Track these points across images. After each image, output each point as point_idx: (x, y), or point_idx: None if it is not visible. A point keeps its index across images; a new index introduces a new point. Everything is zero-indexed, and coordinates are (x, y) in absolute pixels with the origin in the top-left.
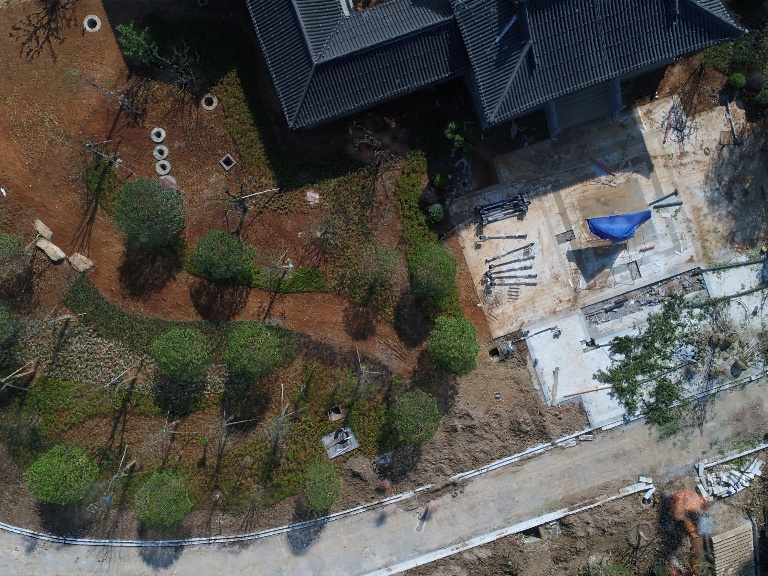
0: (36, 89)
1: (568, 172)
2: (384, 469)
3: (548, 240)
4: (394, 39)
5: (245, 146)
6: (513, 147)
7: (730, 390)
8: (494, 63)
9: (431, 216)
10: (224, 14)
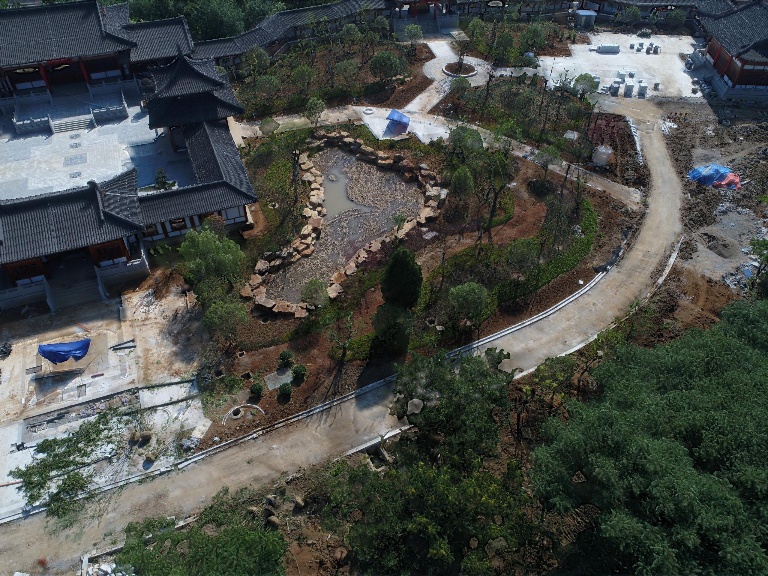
0: None
1: (55, 331)
2: None
3: (18, 372)
4: None
5: None
6: (20, 319)
7: (139, 482)
8: None
9: None
10: None
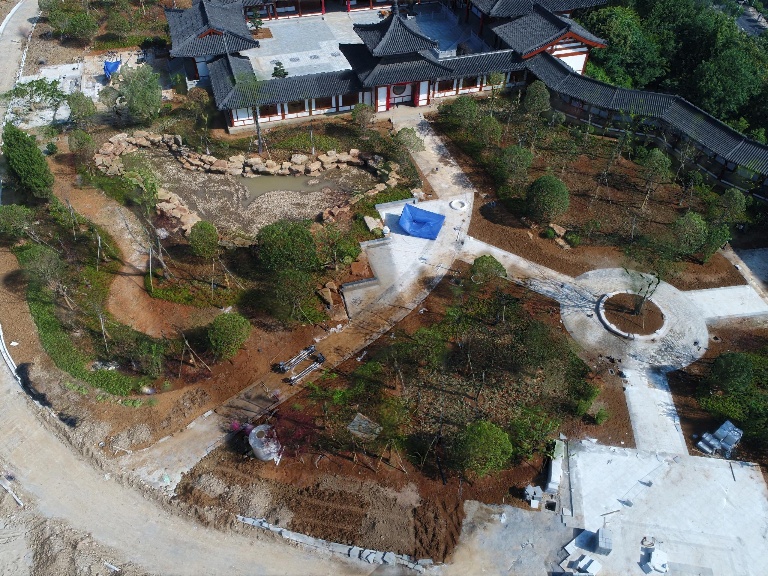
0: None
1: None
2: (46, 34)
3: None
4: None
5: None
6: None
7: None
8: None
9: None
10: None
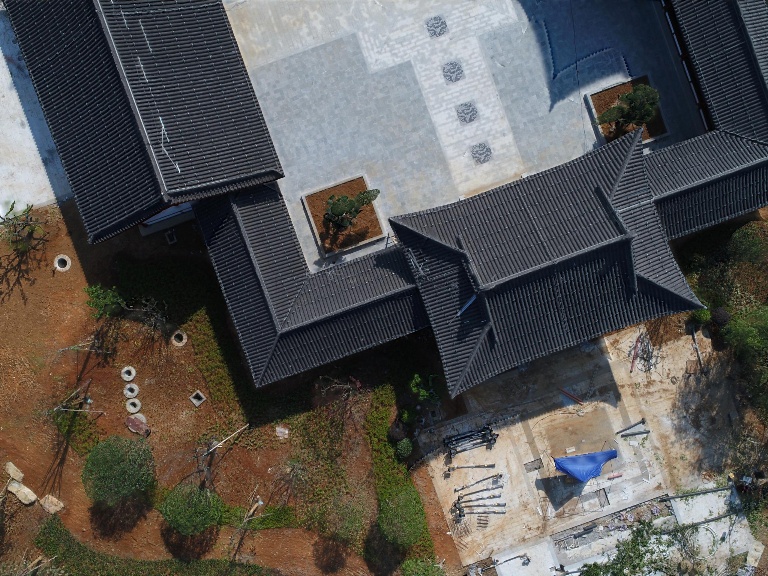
0: (7, 332)
1: (536, 402)
2: None
3: (517, 469)
4: (357, 307)
5: (215, 383)
6: None
7: None
8: (456, 335)
9: (399, 452)
10: (193, 251)
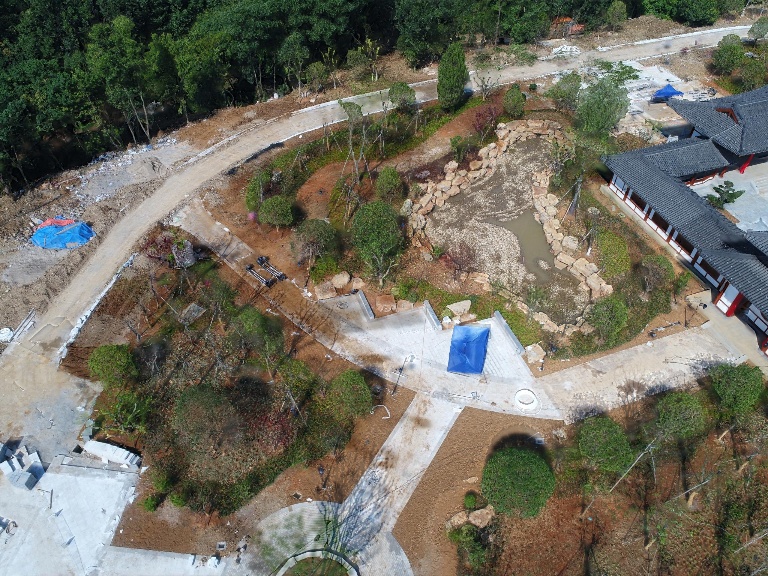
0: None
1: None
2: None
3: None
4: None
5: None
6: None
7: None
8: None
9: None
10: None
